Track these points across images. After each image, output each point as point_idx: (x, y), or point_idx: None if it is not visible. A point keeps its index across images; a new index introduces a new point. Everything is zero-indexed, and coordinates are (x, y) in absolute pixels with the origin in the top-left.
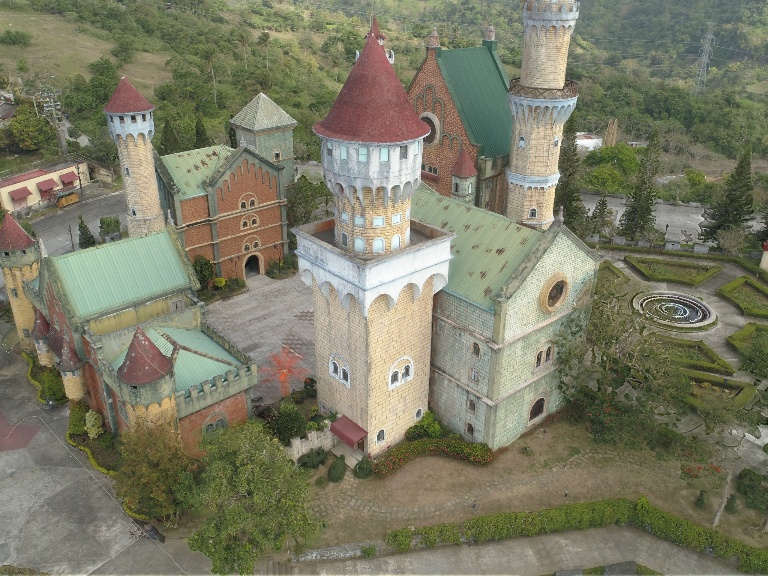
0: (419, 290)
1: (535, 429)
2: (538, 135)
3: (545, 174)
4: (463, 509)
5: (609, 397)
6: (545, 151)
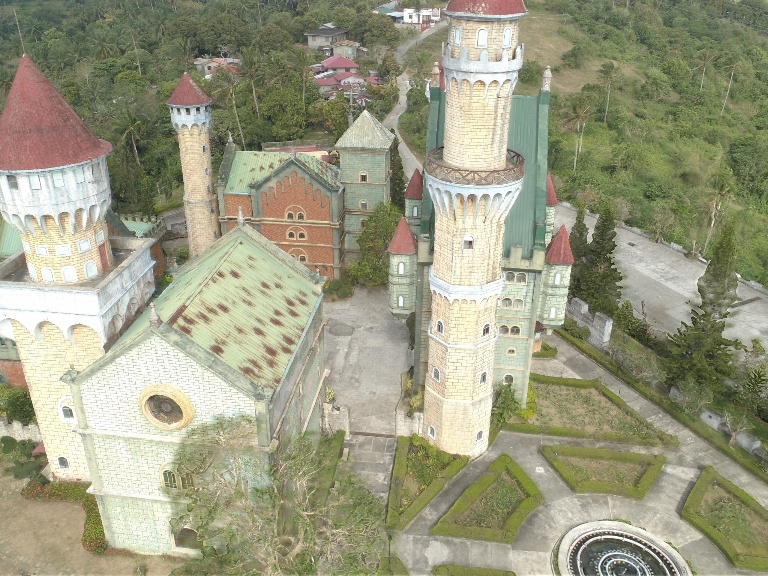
0: (64, 333)
1: (186, 560)
2: (442, 225)
3: (450, 281)
4: (18, 571)
5: (183, 572)
6: (449, 249)
